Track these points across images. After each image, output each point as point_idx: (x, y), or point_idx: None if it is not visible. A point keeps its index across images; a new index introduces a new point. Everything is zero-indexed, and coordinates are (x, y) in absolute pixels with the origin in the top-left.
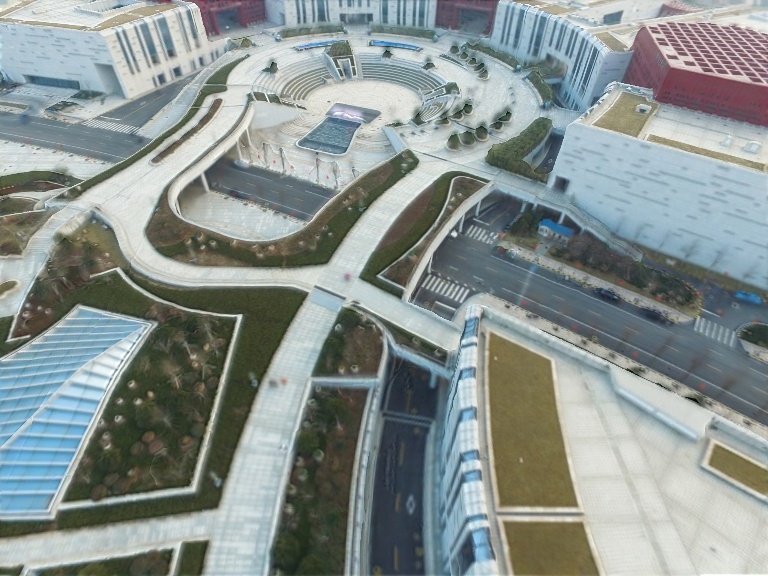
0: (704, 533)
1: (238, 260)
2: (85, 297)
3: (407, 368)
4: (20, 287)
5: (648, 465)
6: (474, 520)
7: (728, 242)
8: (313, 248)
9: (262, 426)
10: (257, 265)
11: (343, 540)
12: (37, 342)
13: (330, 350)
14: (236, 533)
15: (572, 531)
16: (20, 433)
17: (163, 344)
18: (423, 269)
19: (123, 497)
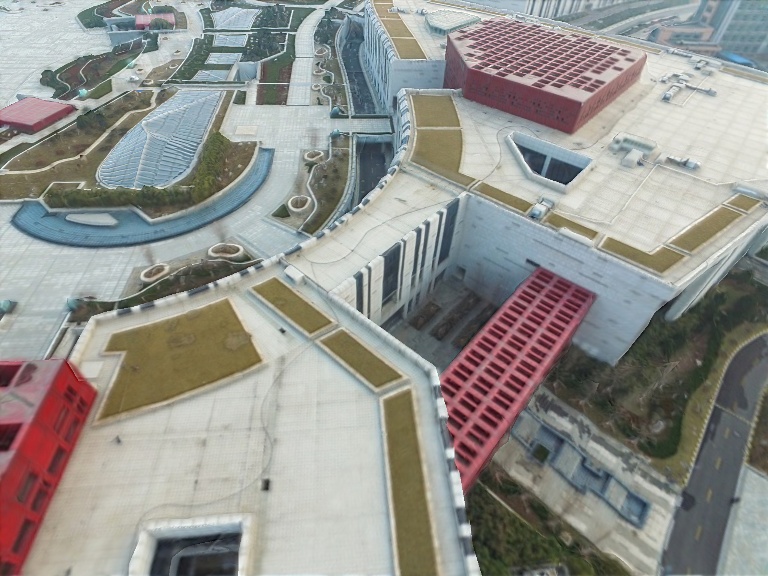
0: (422, 6)
1: (288, 3)
2: (233, 6)
3: (355, 28)
4: (205, 5)
5: (414, 2)
6: (366, 2)
7: (484, 3)
8: (317, 0)
9: (306, 24)
10: (295, 4)
11: (334, 39)
12: (223, 11)
13: (327, 12)
14: (303, 34)
15: (390, 4)
16: (232, 18)
17: (269, 8)
18: (362, 8)
19: (269, 28)
